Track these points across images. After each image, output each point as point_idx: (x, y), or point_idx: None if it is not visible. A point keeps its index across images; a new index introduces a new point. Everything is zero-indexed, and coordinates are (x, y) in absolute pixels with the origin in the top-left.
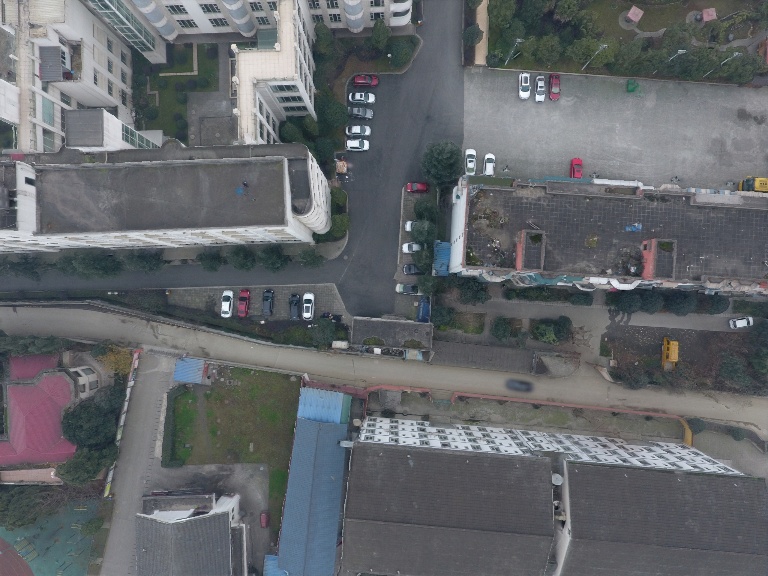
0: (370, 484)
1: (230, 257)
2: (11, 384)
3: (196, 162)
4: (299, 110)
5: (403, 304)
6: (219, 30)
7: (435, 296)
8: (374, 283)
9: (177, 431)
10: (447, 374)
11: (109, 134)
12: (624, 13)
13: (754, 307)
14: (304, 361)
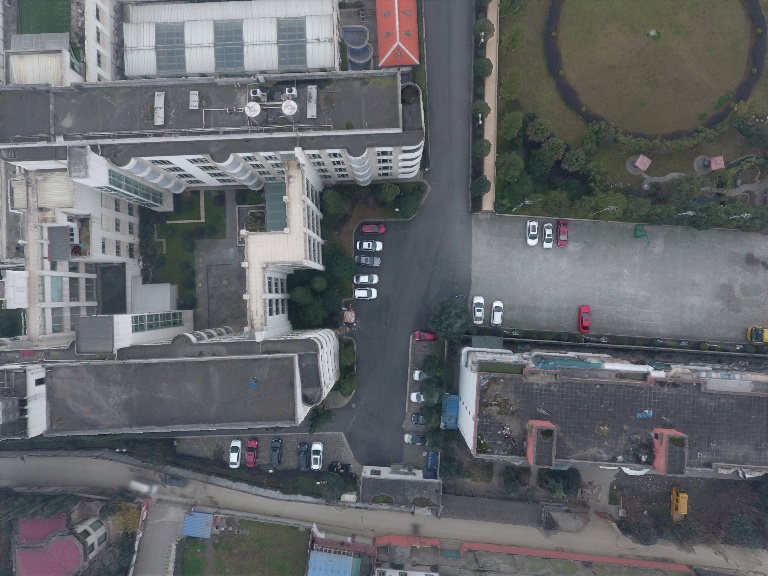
0: None
1: None
2: (20, 548)
3: (206, 359)
4: (307, 267)
5: (411, 453)
6: (226, 184)
7: (444, 449)
8: (382, 431)
9: None
10: (456, 523)
11: (119, 337)
12: (632, 158)
13: None
14: (312, 510)
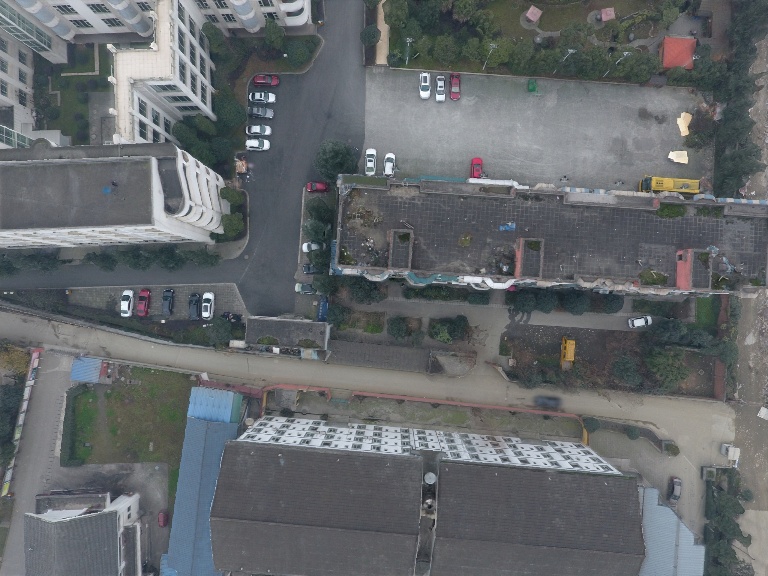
0: (238, 483)
1: (116, 256)
2: None
3: (64, 162)
4: (194, 110)
5: (303, 303)
6: (116, 30)
7: (332, 295)
8: (274, 282)
9: (77, 430)
10: (347, 373)
11: None
12: (525, 13)
13: (653, 306)
14: (204, 360)
